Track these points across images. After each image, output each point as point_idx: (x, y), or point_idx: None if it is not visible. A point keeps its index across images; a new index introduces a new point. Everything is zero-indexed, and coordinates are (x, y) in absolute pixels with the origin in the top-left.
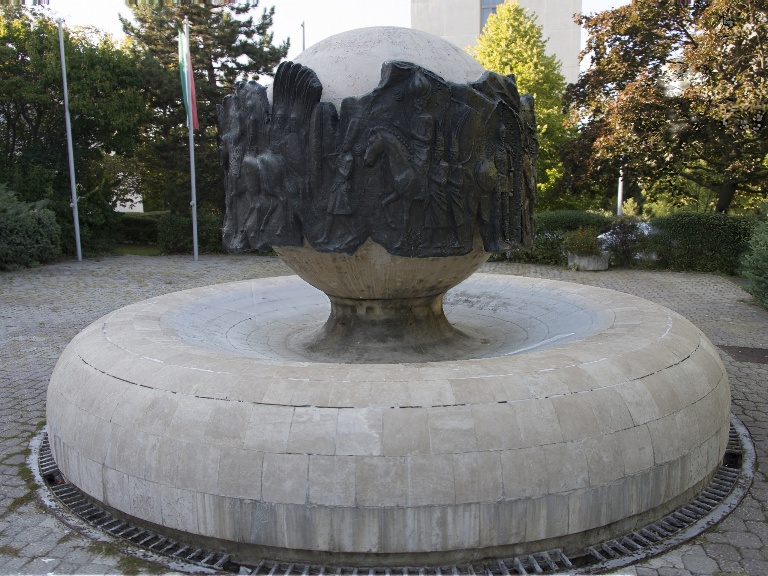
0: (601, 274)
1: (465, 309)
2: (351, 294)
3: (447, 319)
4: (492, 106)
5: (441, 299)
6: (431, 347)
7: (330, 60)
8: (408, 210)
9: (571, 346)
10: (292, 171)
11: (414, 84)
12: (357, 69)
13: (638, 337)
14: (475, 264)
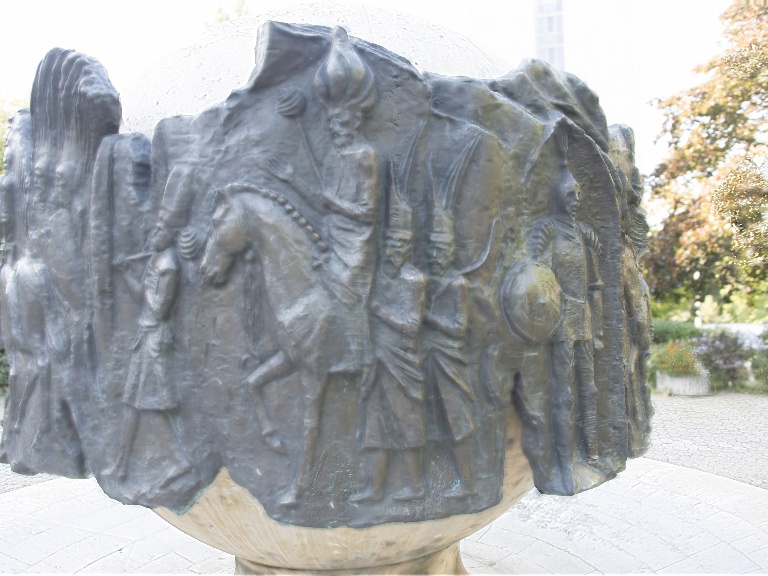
0: (709, 401)
1: (515, 524)
2: (244, 557)
3: (480, 550)
4: (540, 130)
5: (454, 548)
6: None
7: (177, 55)
8: (315, 401)
9: None
10: (59, 298)
11: (324, 69)
12: (220, 63)
13: None
14: (519, 492)
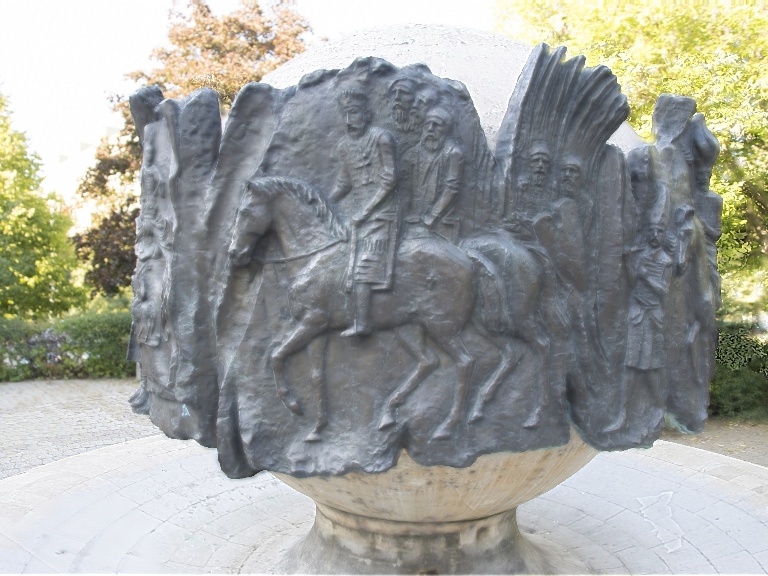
0: None
1: None
2: (485, 513)
3: None
4: None
5: None
6: (552, 568)
7: None
8: (708, 352)
9: None
10: (563, 281)
11: (711, 142)
12: None
13: None
14: None
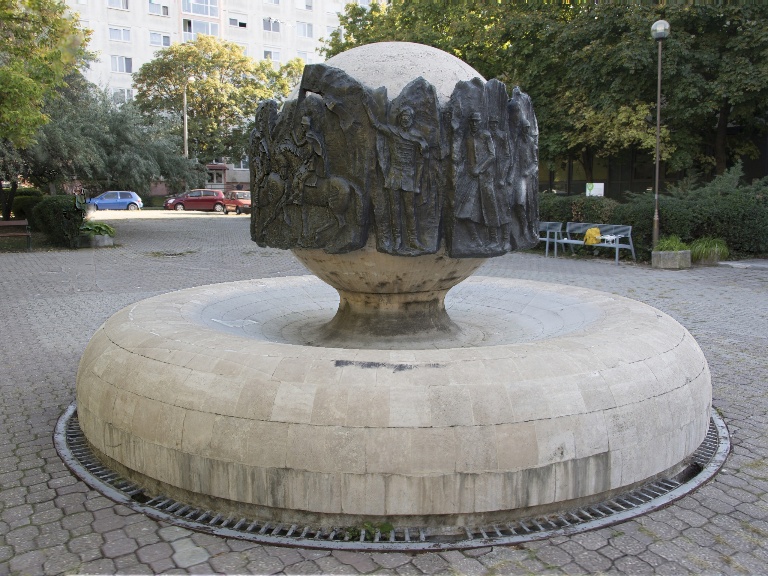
0: None
1: None
2: None
3: None
4: None
5: None
6: None
7: None
8: None
9: (192, 295)
10: None
11: None
12: None
13: (153, 302)
14: None
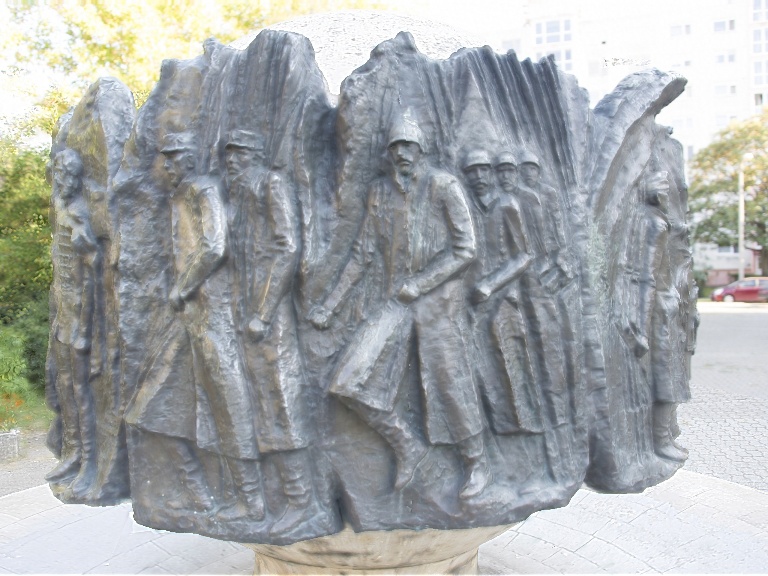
0: None
1: None
2: None
3: None
4: None
5: None
6: None
7: None
8: None
9: None
10: None
11: None
12: None
13: None
14: None
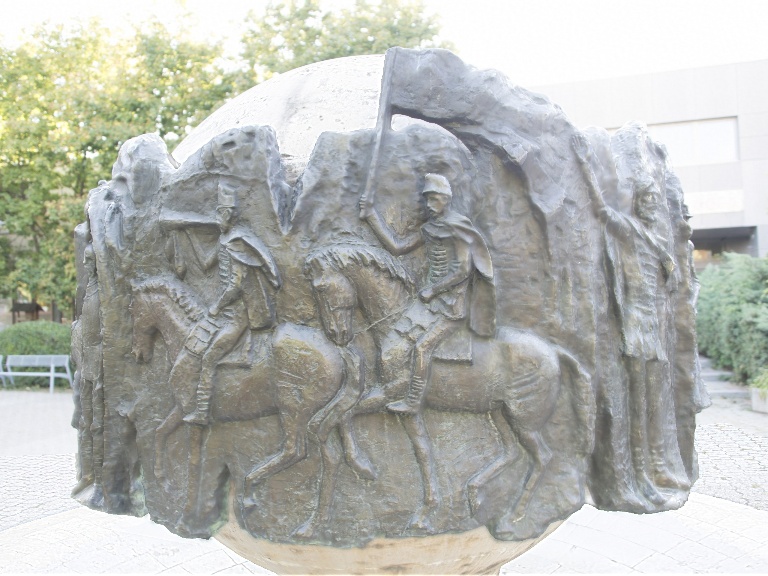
0: None
1: None
2: None
3: None
4: None
5: None
6: None
7: None
8: None
9: None
10: None
11: None
12: None
13: None
14: None
